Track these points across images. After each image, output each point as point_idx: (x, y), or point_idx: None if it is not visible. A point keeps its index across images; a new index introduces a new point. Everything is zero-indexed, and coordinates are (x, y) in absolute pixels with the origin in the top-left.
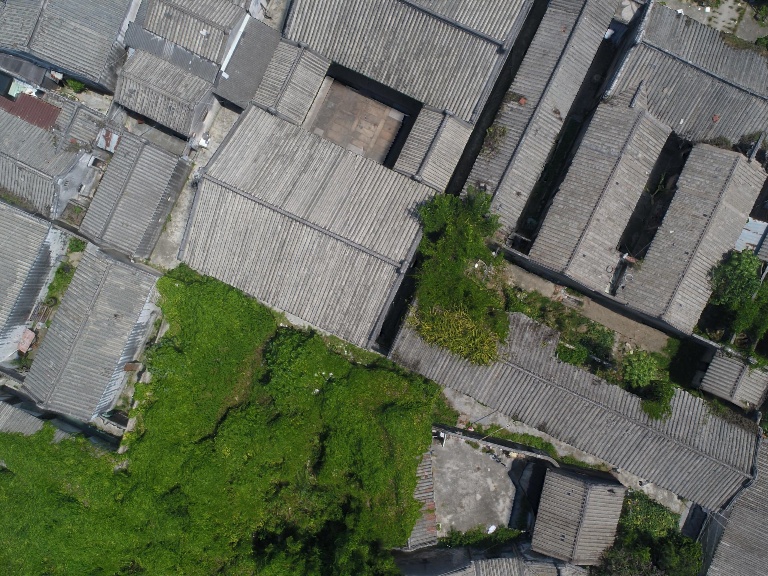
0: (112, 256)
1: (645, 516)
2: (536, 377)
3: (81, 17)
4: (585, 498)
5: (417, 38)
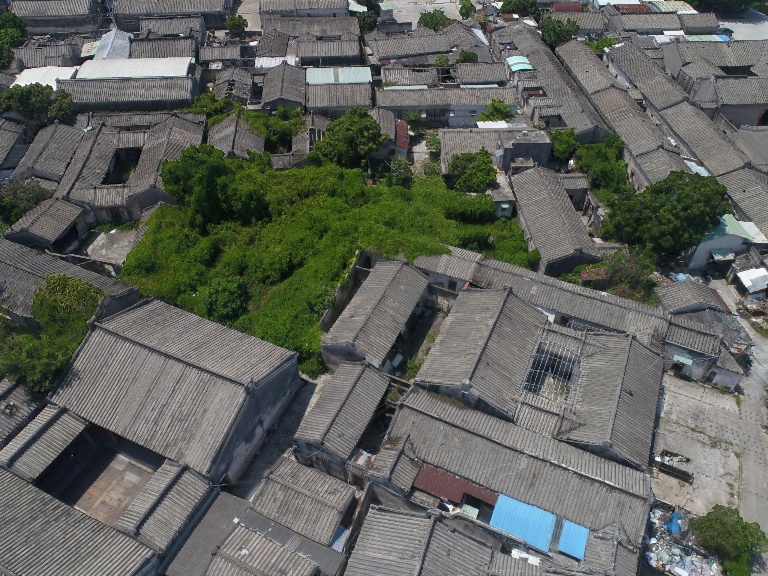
0: (357, 358)
1: (1, 229)
2: (25, 269)
3: (383, 568)
4: (31, 224)
5: (3, 533)
